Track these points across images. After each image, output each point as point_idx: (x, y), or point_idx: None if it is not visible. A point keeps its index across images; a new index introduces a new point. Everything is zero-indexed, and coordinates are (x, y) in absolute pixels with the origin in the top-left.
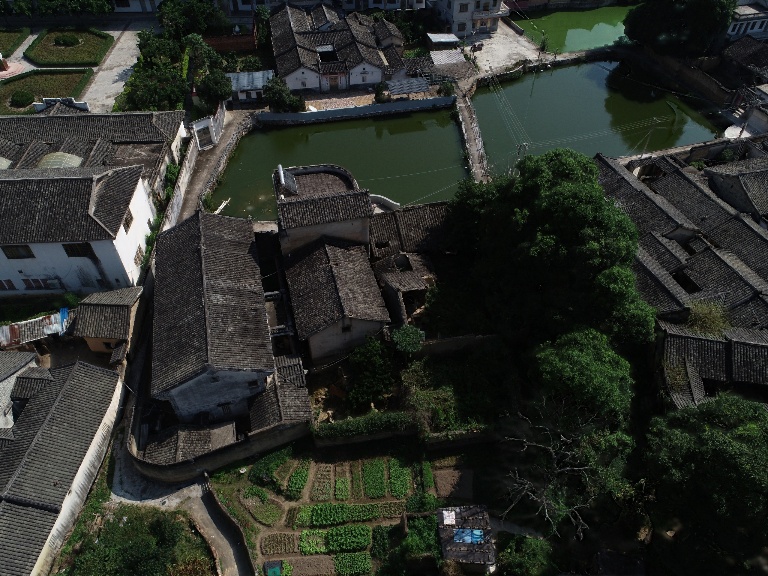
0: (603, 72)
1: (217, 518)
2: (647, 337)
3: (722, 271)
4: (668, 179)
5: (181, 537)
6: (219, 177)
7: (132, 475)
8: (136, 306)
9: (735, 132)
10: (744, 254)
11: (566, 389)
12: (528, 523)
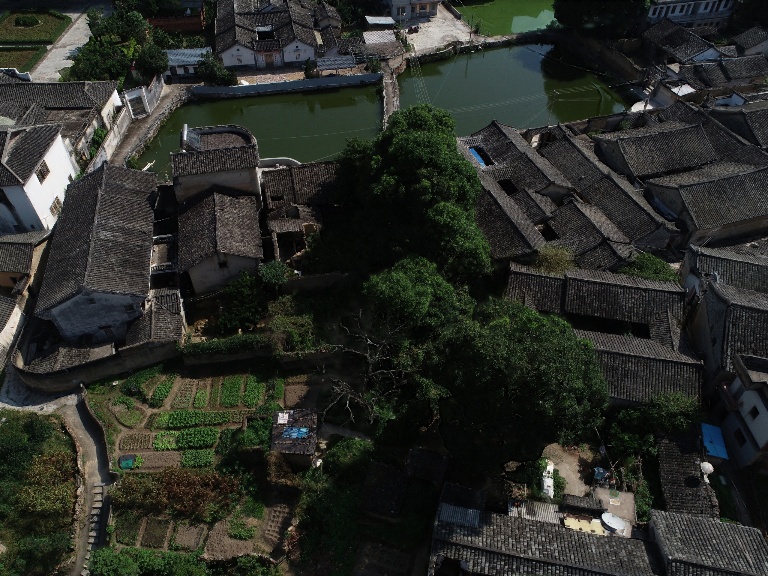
0: (538, 55)
1: (87, 421)
2: (482, 270)
3: (579, 221)
4: (556, 144)
5: (51, 435)
6: (148, 142)
7: (18, 386)
8: (43, 246)
9: (641, 107)
10: (609, 209)
11: (380, 302)
12: (358, 427)
